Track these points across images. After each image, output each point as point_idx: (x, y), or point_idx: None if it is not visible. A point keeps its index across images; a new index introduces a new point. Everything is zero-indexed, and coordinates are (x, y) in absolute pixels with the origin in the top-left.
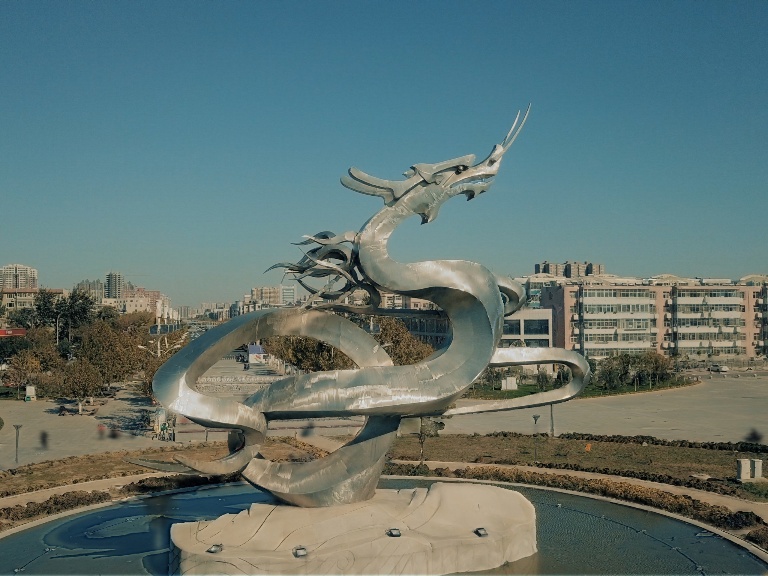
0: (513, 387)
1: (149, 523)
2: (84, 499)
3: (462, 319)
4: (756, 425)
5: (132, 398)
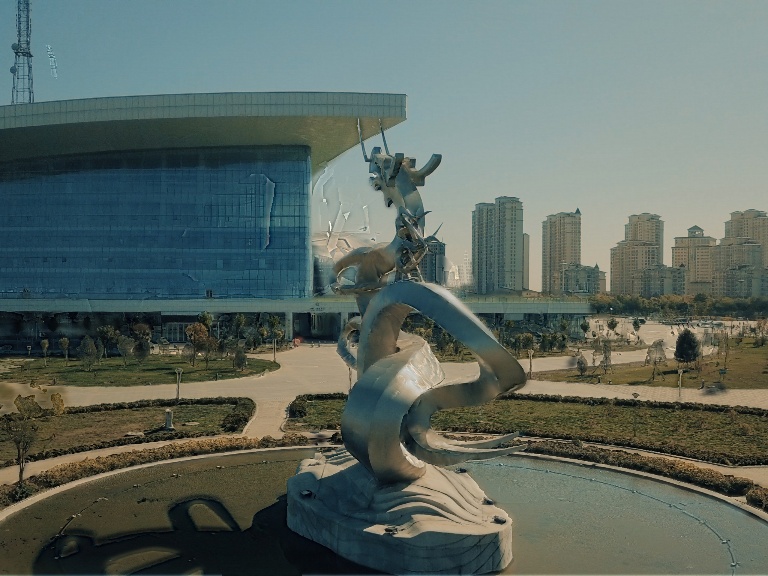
0: None
1: None
2: None
3: None
4: None
5: None
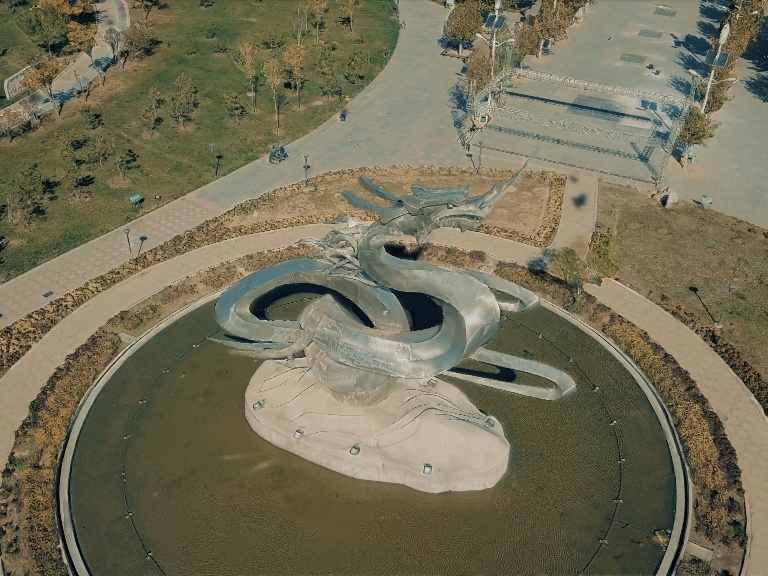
0: None
1: None
2: None
3: (450, 318)
4: None
5: None
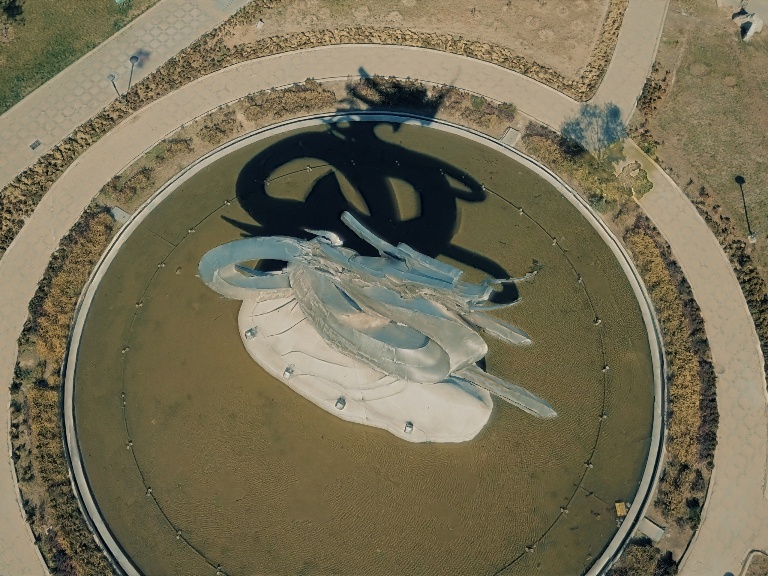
0: None
1: (317, 182)
2: (309, 103)
3: None
4: None
5: None
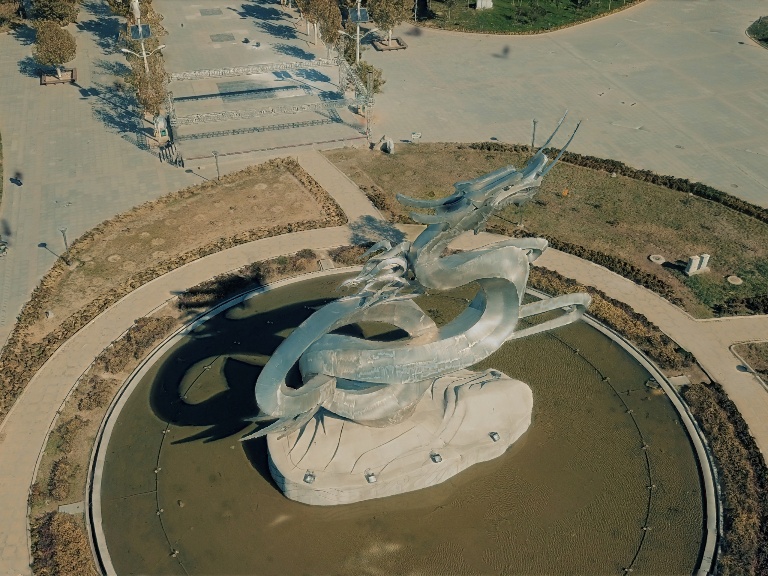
0: (488, 5)
1: (224, 372)
2: (157, 332)
3: (495, 292)
4: (715, 118)
5: (95, 22)
